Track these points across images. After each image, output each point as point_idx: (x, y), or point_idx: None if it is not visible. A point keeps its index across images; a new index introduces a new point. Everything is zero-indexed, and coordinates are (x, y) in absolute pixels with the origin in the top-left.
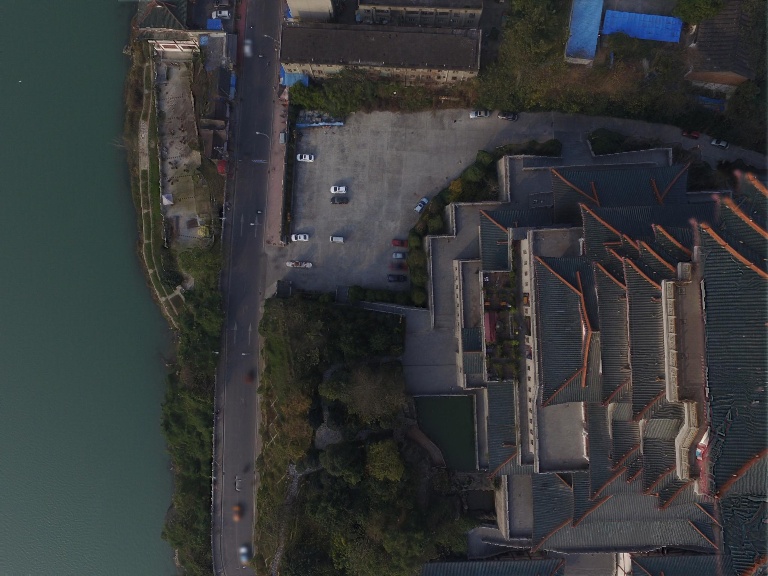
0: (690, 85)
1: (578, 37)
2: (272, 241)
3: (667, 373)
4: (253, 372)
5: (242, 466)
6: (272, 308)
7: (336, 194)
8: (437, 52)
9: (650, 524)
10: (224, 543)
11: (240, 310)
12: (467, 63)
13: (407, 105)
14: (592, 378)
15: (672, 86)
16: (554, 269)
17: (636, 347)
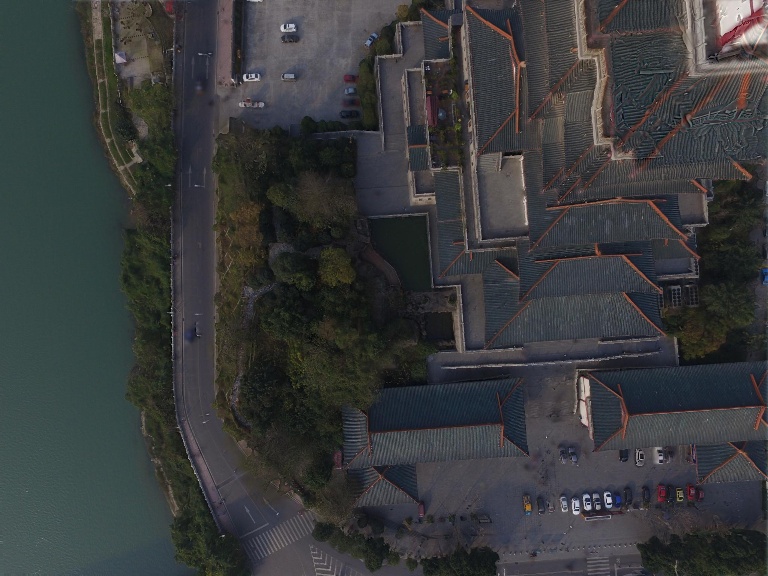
0: None
1: None
2: (224, 82)
3: (577, 29)
4: (209, 215)
5: (202, 311)
6: (224, 141)
7: (286, 33)
8: None
9: (599, 314)
10: (186, 391)
11: (194, 153)
12: None
13: None
14: (525, 123)
15: None
16: (485, 18)
17: (551, 24)
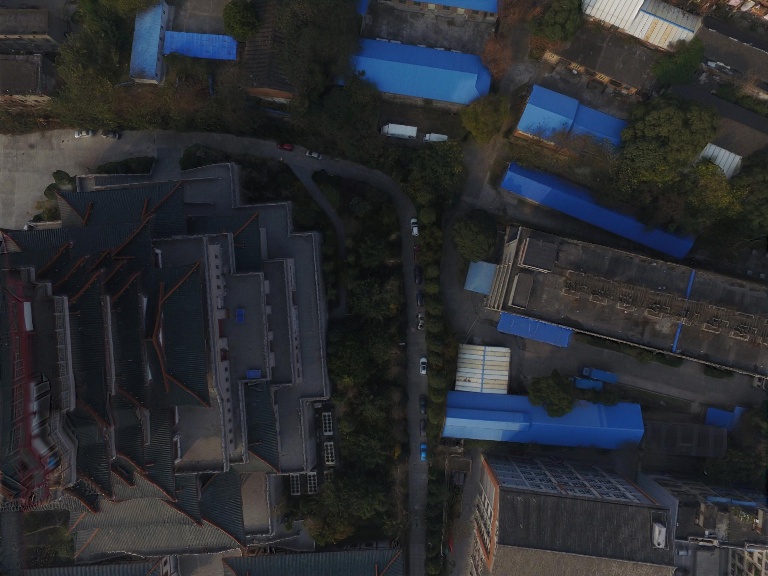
0: (260, 100)
1: (139, 58)
2: None
3: None
4: None
5: None
6: None
7: None
8: (0, 78)
9: (180, 527)
10: None
11: None
12: (29, 87)
13: (14, 127)
14: None
15: (224, 103)
16: None
17: None
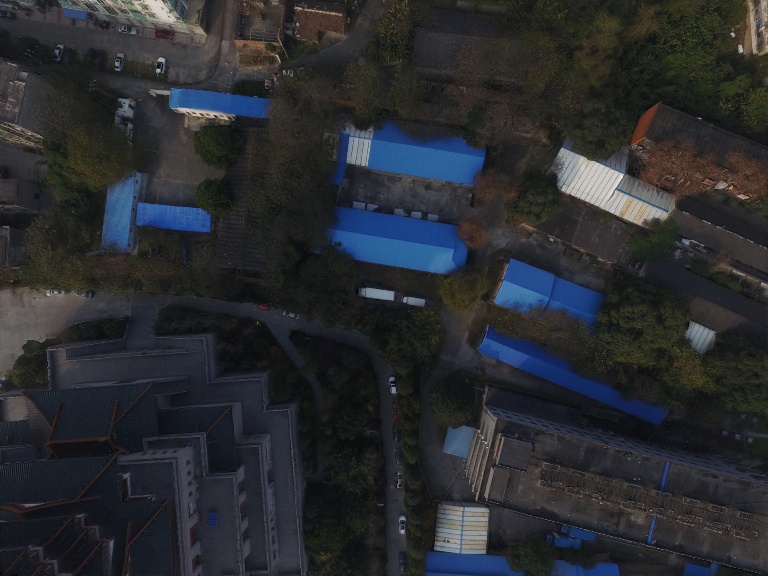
0: (235, 268)
1: (111, 230)
2: None
3: None
4: None
5: None
6: None
7: None
8: None
9: None
10: None
11: None
12: None
13: None
14: None
15: (198, 279)
16: None
17: None
